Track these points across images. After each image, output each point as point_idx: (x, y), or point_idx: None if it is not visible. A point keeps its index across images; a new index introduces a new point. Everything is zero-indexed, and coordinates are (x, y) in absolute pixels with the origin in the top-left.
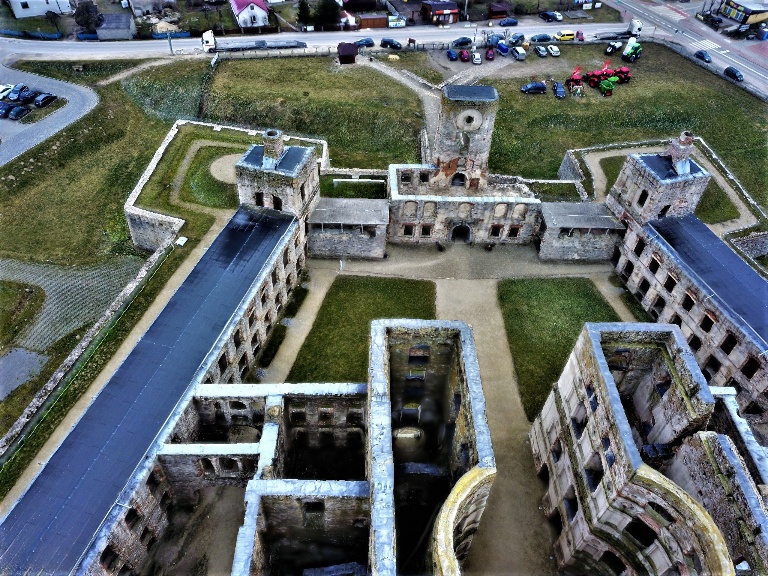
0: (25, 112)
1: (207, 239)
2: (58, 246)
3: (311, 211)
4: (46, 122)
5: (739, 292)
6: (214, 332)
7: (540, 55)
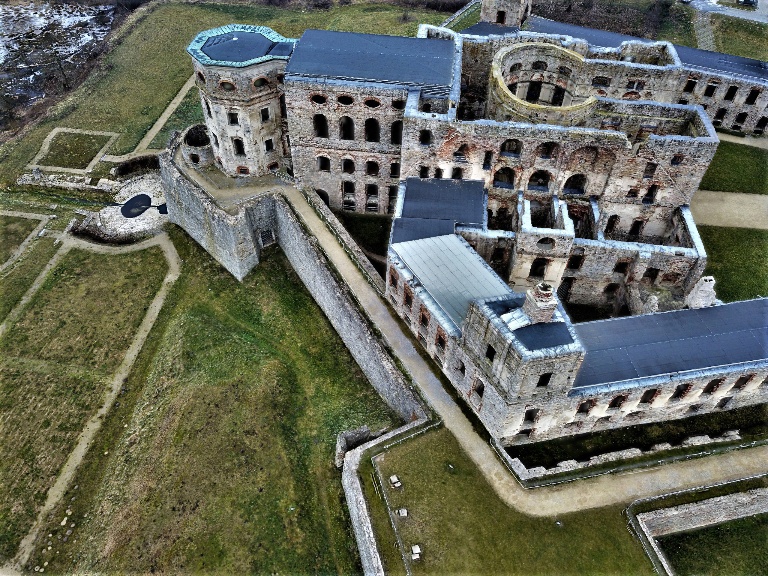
0: None
1: None
2: None
3: None
4: None
5: None
6: None
7: None
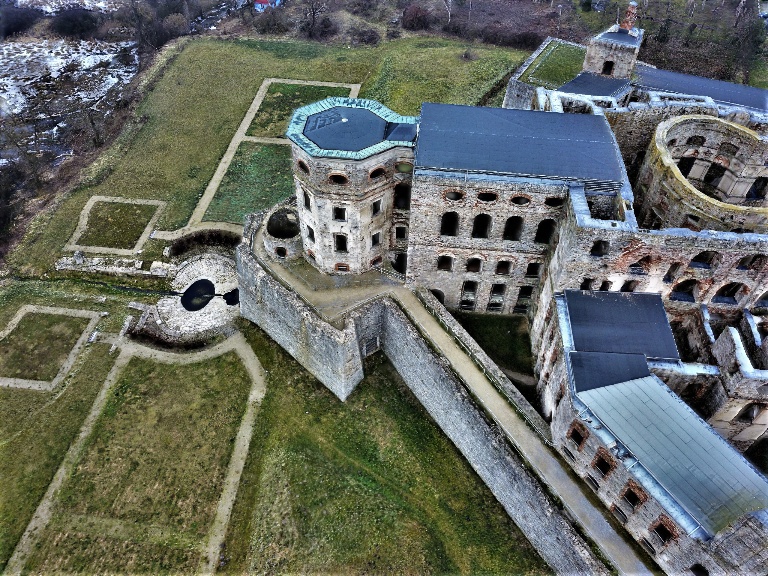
0: None
1: None
2: None
3: None
4: None
5: None
6: None
7: None
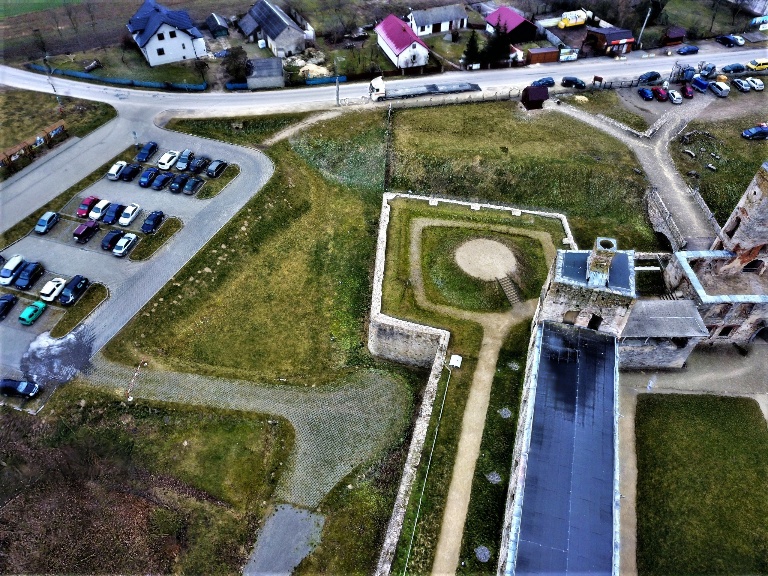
0: (199, 185)
1: (484, 357)
2: (284, 358)
3: None
4: (225, 196)
5: None
6: (605, 523)
7: (743, 90)
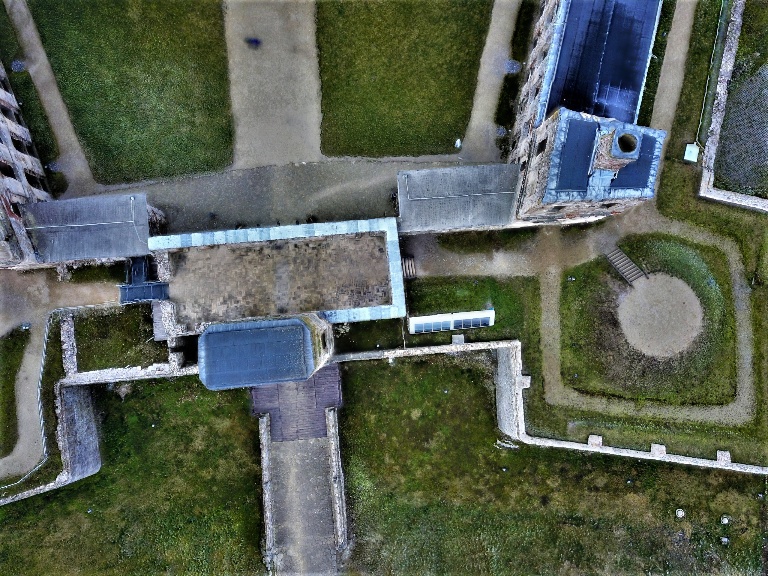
0: None
1: None
2: None
3: None
4: None
5: None
6: None
7: None
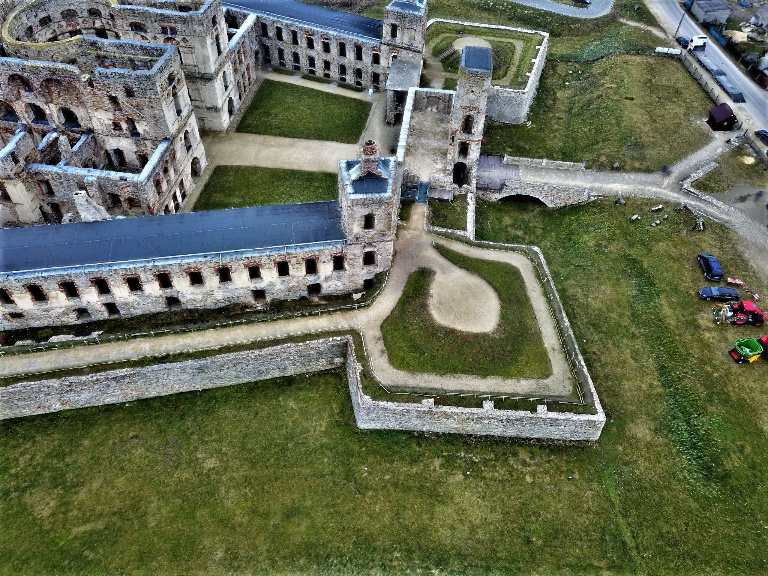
0: None
1: None
2: None
3: (403, 59)
4: (555, 5)
5: (226, 222)
6: None
7: None
